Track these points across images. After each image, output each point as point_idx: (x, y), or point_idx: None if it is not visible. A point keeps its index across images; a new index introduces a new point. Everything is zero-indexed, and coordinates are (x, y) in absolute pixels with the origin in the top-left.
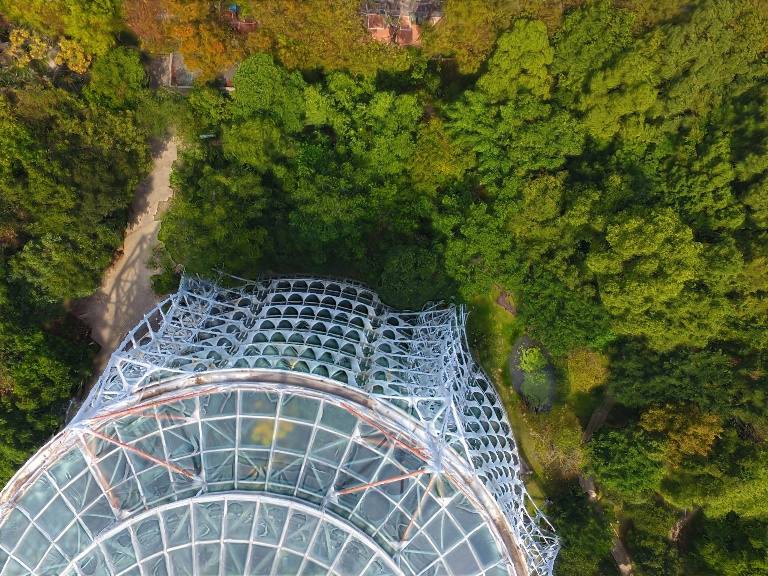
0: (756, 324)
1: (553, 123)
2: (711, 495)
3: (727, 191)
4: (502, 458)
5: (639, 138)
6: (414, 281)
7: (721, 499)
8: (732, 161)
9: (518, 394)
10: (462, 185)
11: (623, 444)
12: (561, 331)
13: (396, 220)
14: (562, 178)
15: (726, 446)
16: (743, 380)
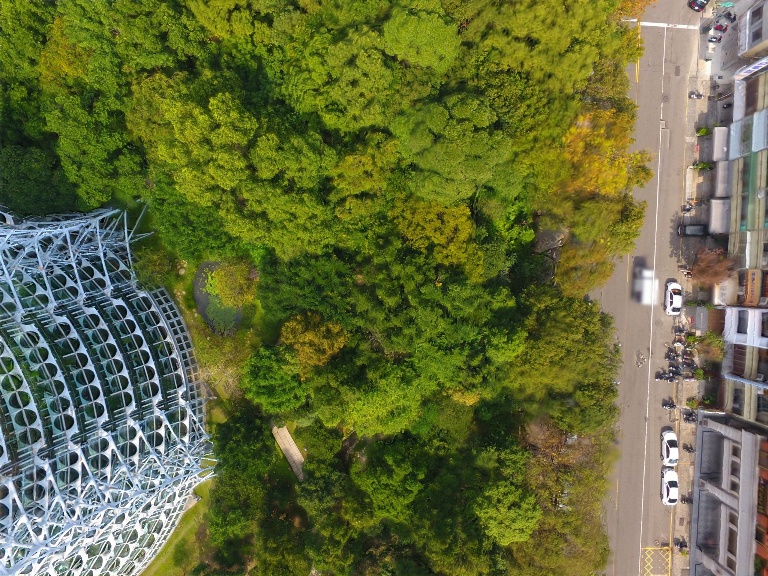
0: (357, 226)
1: (155, 18)
2: (324, 405)
3: (329, 89)
4: (122, 367)
5: (255, 37)
6: (17, 180)
7: (357, 414)
8: (323, 55)
9: (203, 318)
10: (94, 89)
11: (266, 359)
12: (187, 238)
13: (26, 124)
14: (181, 79)
15: (355, 358)
16: (357, 287)
